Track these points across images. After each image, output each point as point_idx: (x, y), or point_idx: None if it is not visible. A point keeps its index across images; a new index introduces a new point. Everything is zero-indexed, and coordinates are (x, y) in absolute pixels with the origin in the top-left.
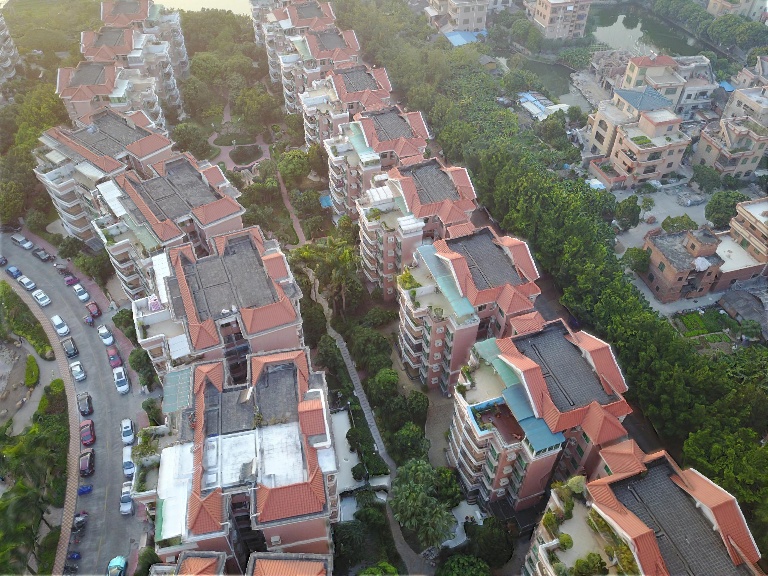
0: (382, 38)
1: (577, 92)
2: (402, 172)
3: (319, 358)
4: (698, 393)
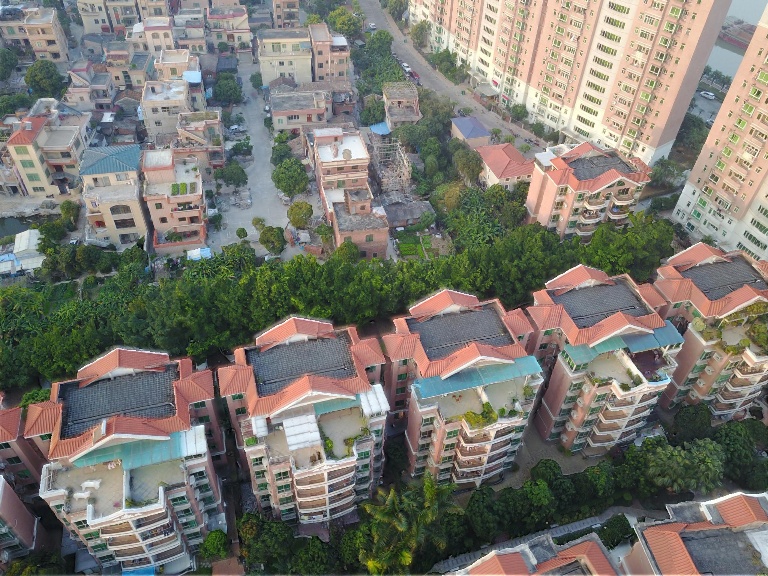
0: None
1: None
2: (260, 396)
3: None
4: None
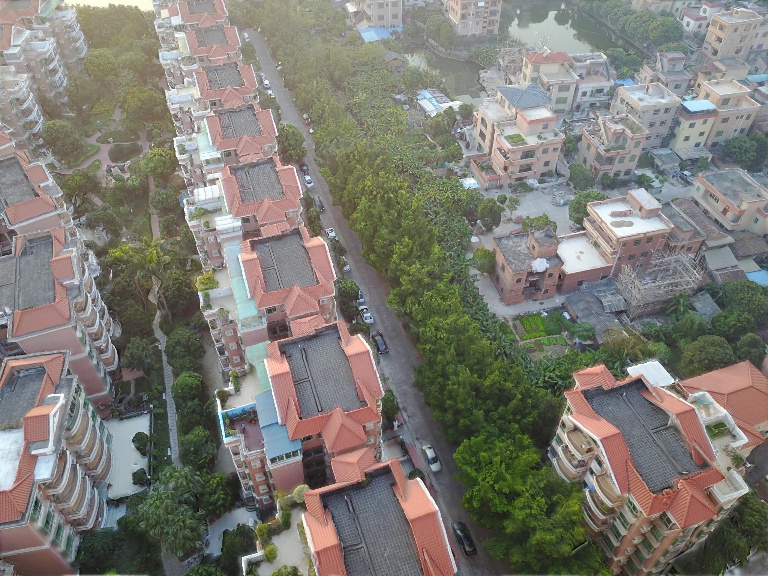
0: (286, 34)
1: (481, 89)
2: (235, 171)
3: (124, 360)
4: (487, 398)
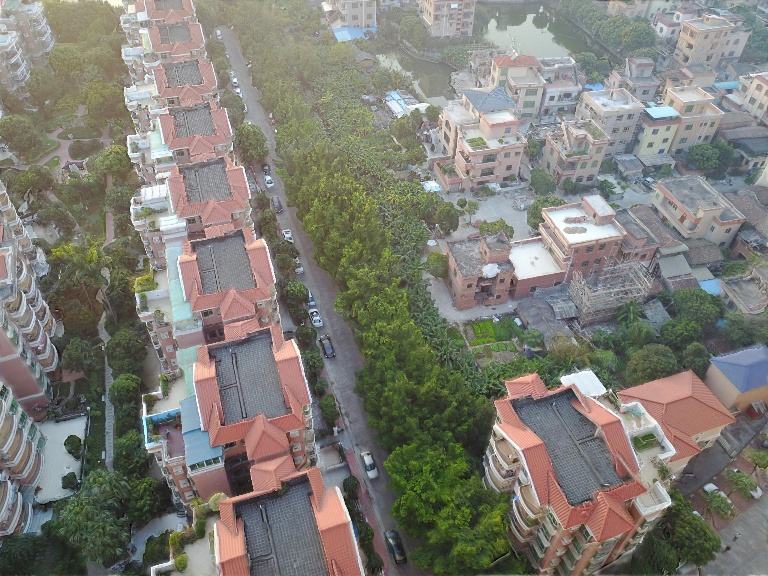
0: (256, 32)
1: (451, 91)
2: (185, 170)
3: (62, 361)
4: (424, 405)
